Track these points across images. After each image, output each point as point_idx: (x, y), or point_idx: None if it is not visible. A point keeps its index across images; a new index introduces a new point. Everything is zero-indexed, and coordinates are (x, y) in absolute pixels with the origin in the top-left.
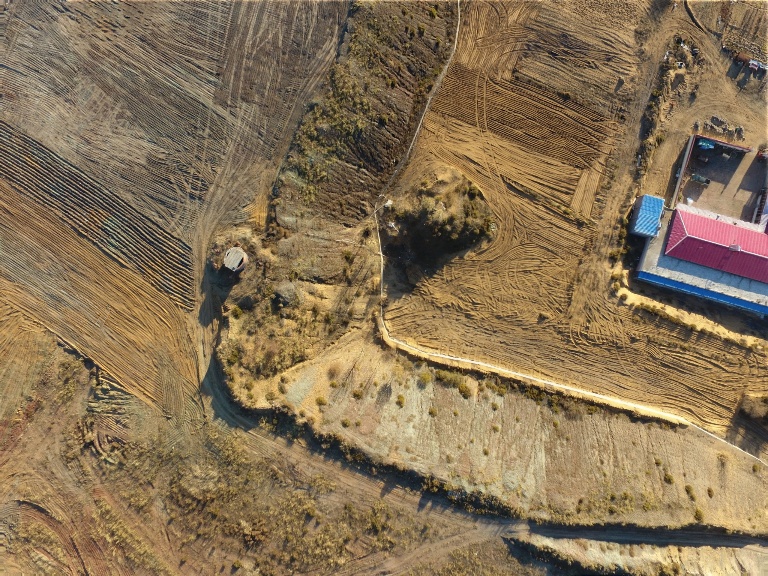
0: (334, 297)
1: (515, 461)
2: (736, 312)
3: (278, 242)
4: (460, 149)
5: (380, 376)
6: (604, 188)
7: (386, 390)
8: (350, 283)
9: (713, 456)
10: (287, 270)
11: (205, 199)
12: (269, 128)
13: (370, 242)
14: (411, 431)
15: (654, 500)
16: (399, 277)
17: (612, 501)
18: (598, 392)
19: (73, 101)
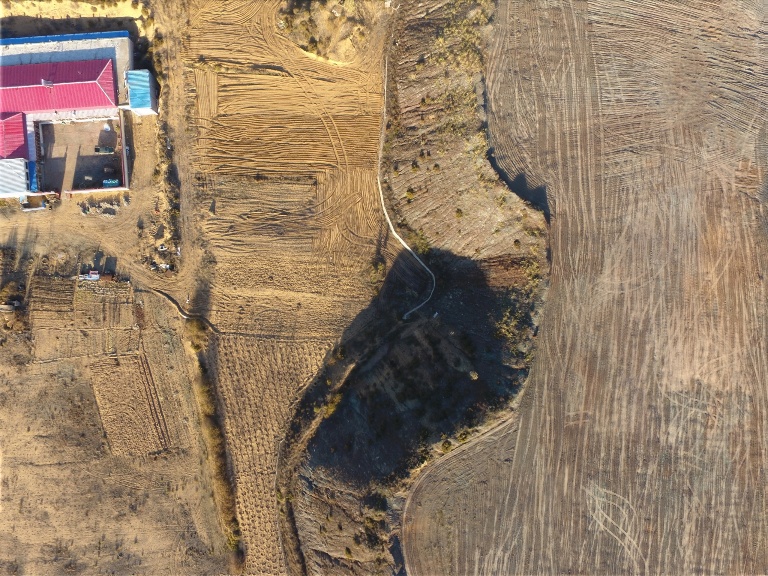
0: None
1: None
2: None
3: None
4: (340, 87)
5: None
6: (191, 105)
7: None
8: None
9: None
10: None
11: None
12: None
13: None
14: None
15: None
16: None
17: None
18: None
19: None
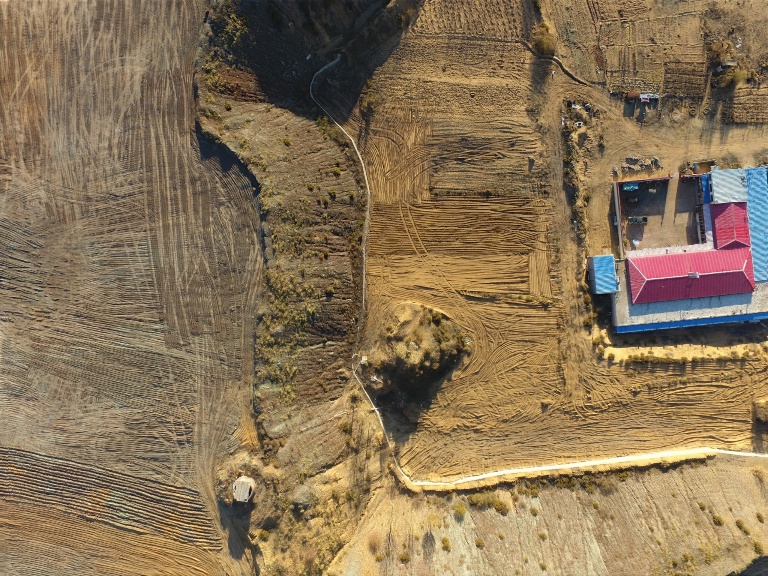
0: (347, 473)
1: (573, 565)
2: (717, 327)
3: (277, 455)
4: (409, 281)
5: (418, 527)
6: (554, 263)
7: (429, 540)
8: (357, 451)
9: (749, 475)
10: (295, 476)
11: (194, 441)
12: (228, 352)
13: (360, 403)
14: (467, 574)
15: (713, 550)
16: (399, 421)
17: (675, 568)
18: (622, 455)
19: (35, 397)
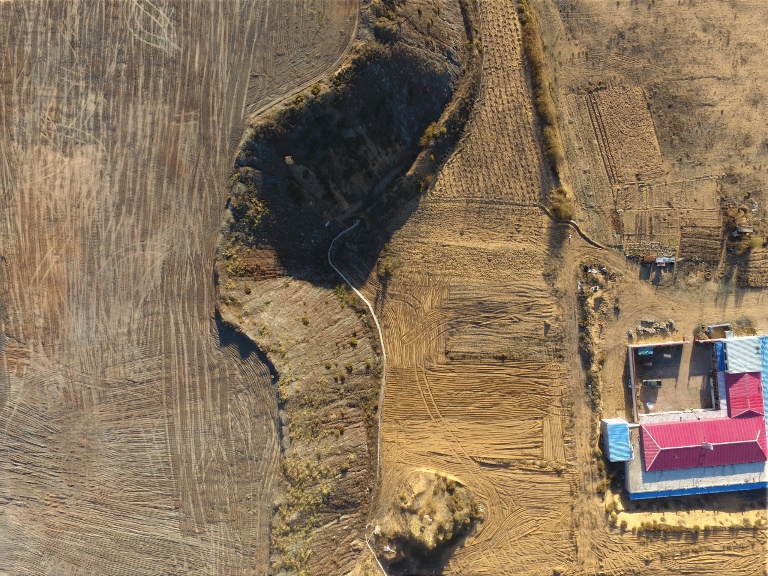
0: None
1: None
2: None
3: None
4: (424, 447)
5: None
6: (568, 428)
7: None
8: None
9: None
10: None
11: None
12: (243, 540)
13: (373, 574)
14: None
15: None
16: None
17: None
18: None
19: None
